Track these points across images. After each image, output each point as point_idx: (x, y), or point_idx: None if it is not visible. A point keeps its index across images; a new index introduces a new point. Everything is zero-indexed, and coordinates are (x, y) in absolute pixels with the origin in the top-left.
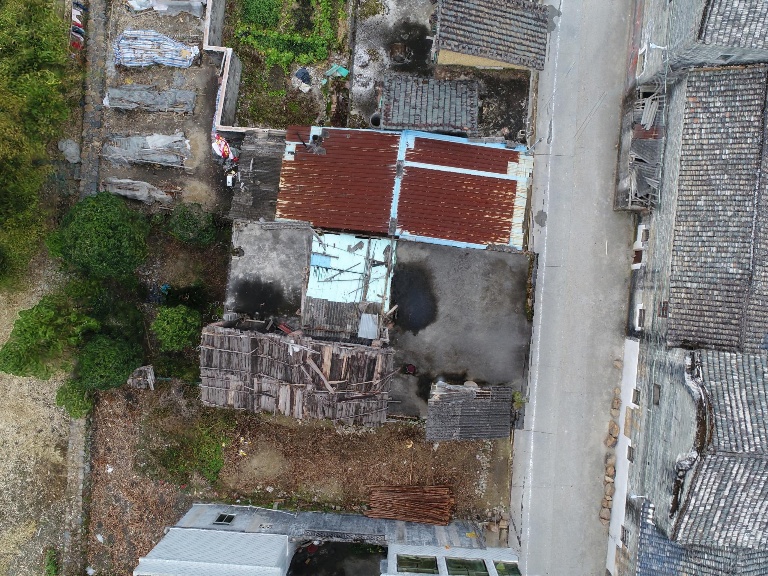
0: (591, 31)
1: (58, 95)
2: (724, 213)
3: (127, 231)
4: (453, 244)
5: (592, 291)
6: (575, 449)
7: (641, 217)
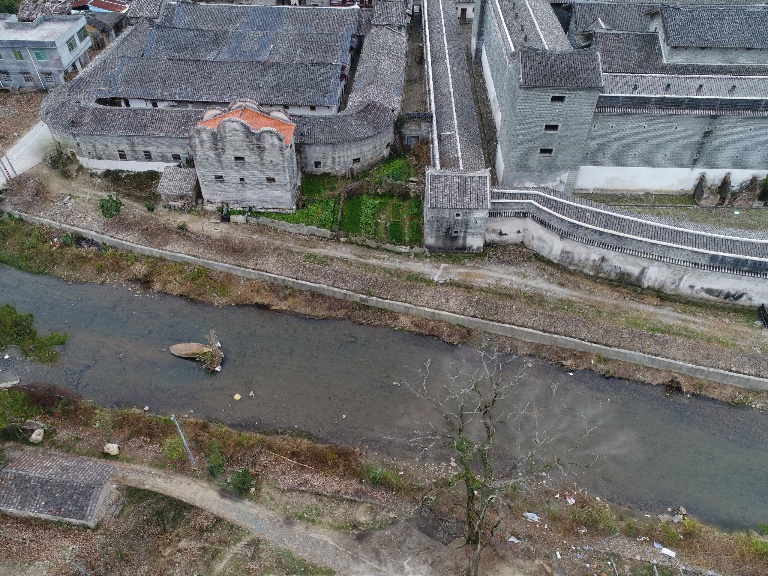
0: None
1: (13, 1)
2: None
3: (16, 7)
4: (104, 11)
5: None
6: None
7: None
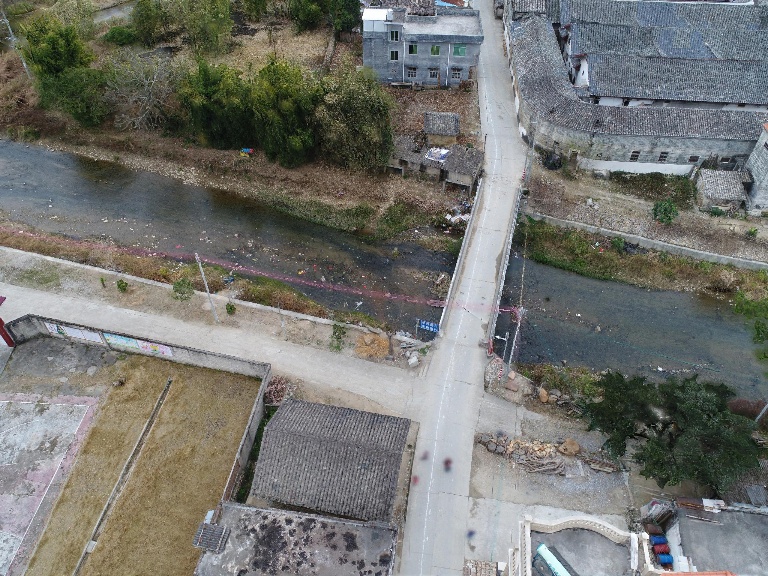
0: (482, 1)
1: None
2: None
3: None
4: (448, 5)
5: (492, 28)
6: (493, 47)
7: None
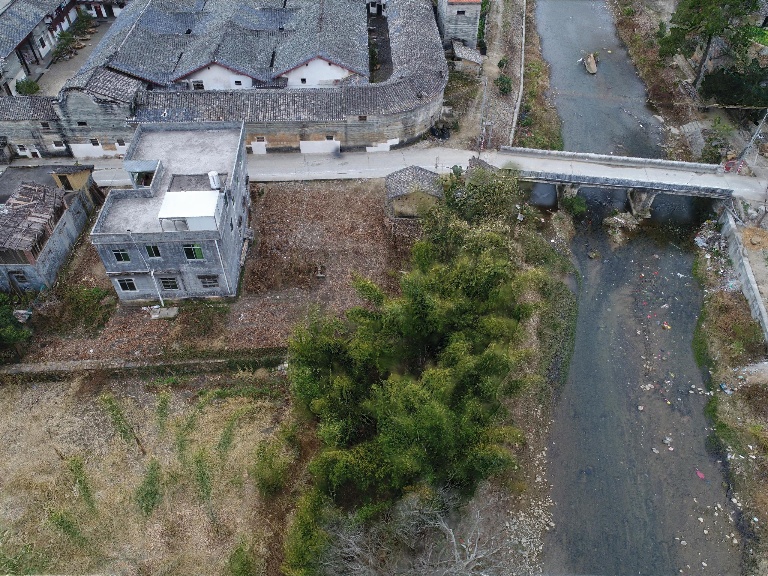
0: None
1: None
2: (3, 106)
3: None
4: None
5: None
6: None
7: (15, 153)
